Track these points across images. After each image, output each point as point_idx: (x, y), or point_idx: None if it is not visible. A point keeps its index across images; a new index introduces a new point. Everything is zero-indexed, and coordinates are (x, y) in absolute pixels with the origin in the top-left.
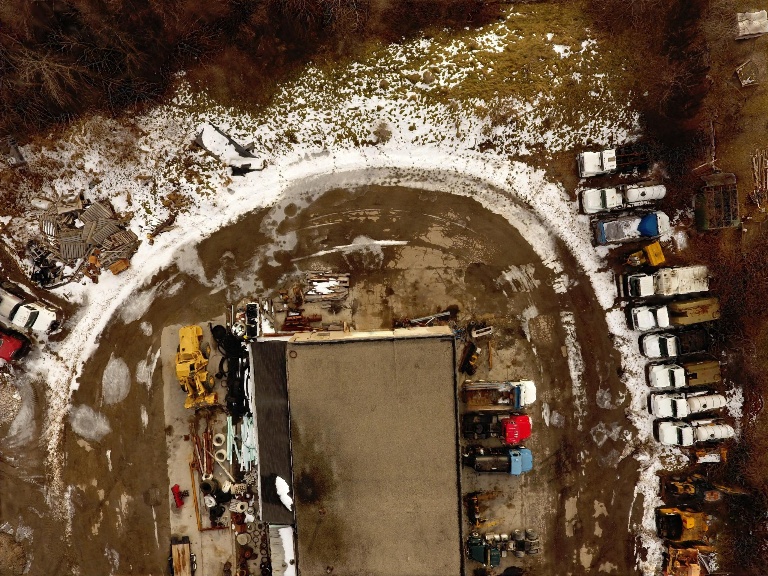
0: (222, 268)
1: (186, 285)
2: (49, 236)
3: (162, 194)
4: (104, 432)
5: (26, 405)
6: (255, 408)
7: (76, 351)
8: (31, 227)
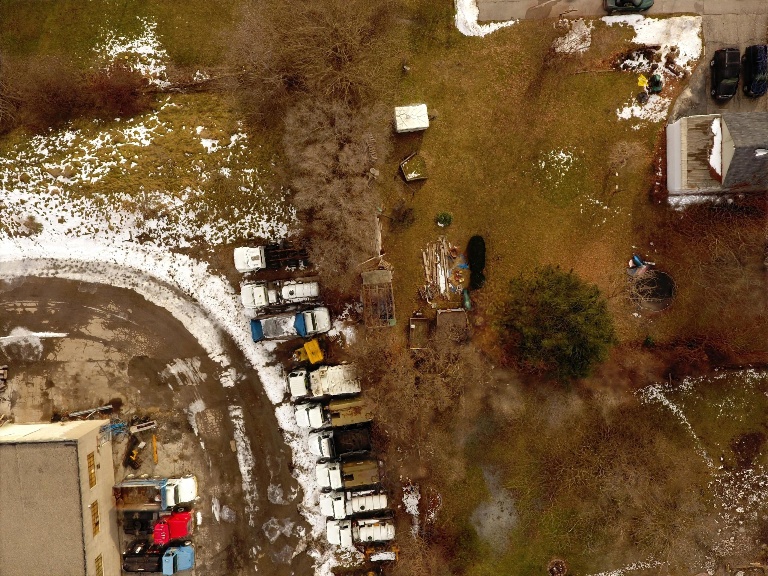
0: None
1: None
2: None
3: None
4: None
5: None
6: None
7: None
8: None
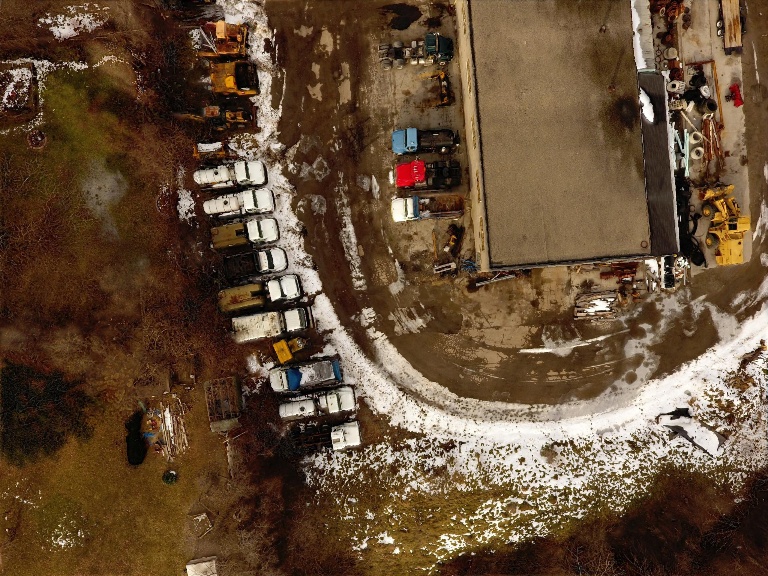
0: (695, 320)
1: None
2: None
3: (755, 389)
4: None
5: None
6: (673, 189)
7: None
8: None
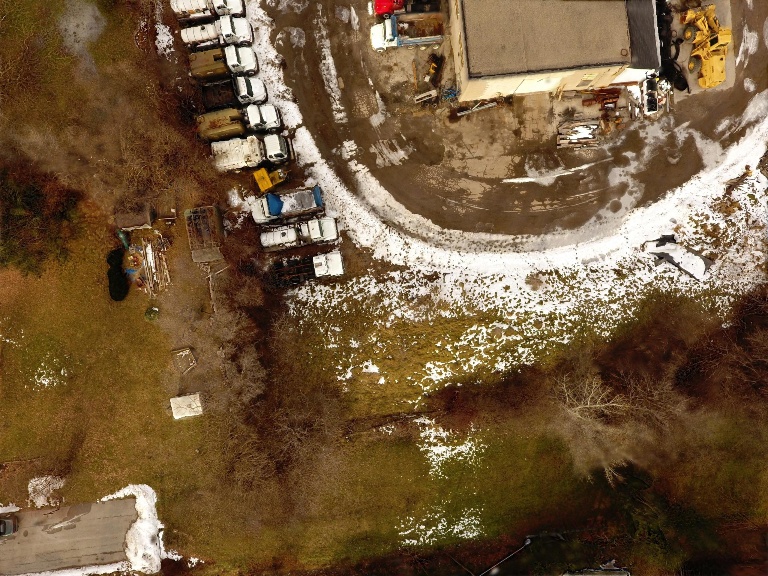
0: (679, 147)
1: None
2: None
3: (741, 212)
4: None
5: None
6: (653, 3)
7: None
8: None
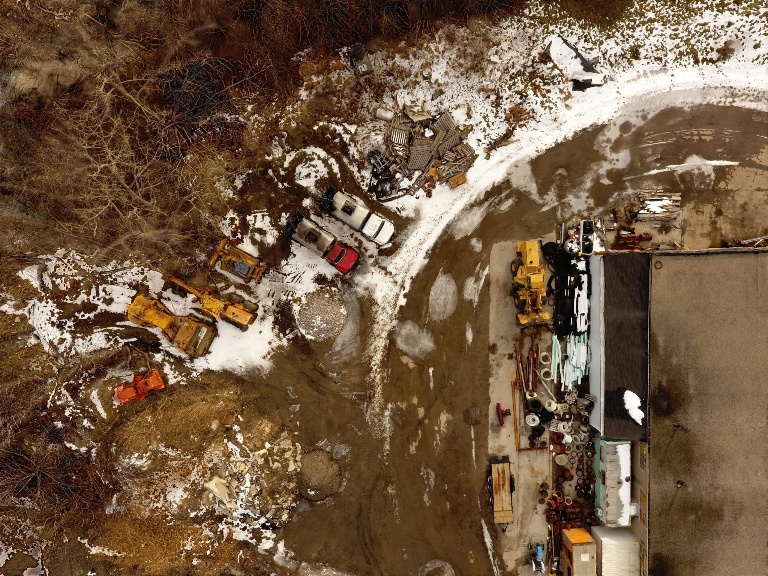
0: (554, 185)
1: (518, 201)
2: (398, 145)
3: (506, 107)
4: (428, 349)
5: (351, 320)
6: (603, 322)
7: (406, 266)
8: (375, 137)
